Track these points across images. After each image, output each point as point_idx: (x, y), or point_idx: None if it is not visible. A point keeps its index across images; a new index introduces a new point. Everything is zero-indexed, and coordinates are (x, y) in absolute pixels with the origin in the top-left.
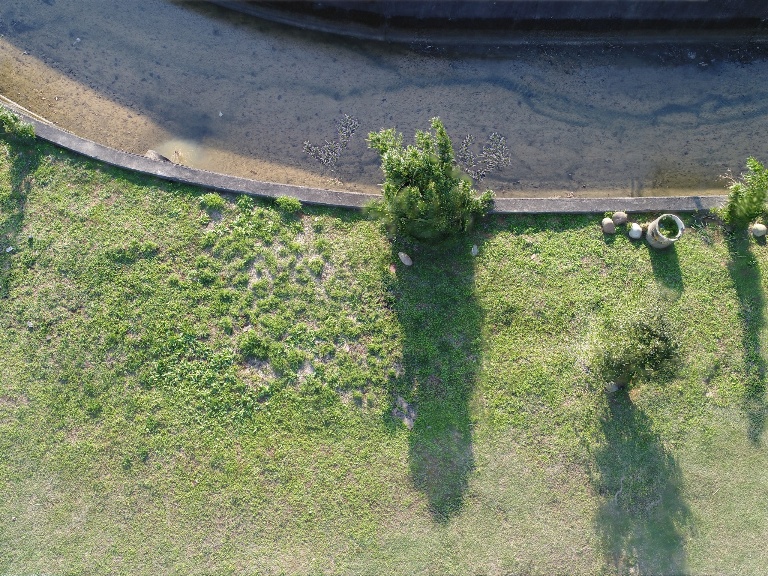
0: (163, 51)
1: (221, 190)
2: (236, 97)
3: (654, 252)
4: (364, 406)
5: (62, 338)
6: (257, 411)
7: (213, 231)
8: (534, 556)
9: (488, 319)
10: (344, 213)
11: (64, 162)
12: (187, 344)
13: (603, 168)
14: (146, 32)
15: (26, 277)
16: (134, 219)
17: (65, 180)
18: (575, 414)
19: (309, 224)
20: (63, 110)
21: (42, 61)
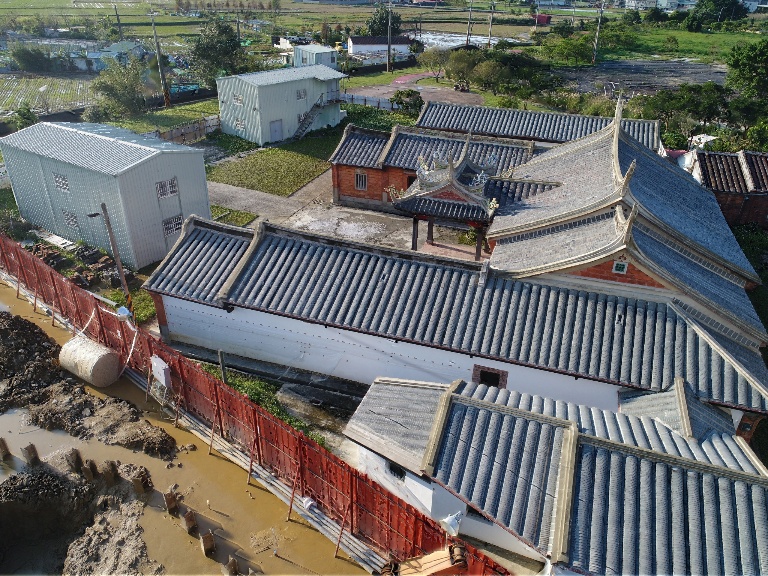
0: None
1: None
2: None
3: None
4: None
5: None
6: None
7: None
8: None
9: None
10: None
11: None
12: None
13: None
14: None
15: None
16: None
17: None
18: None
19: None
20: None
21: None
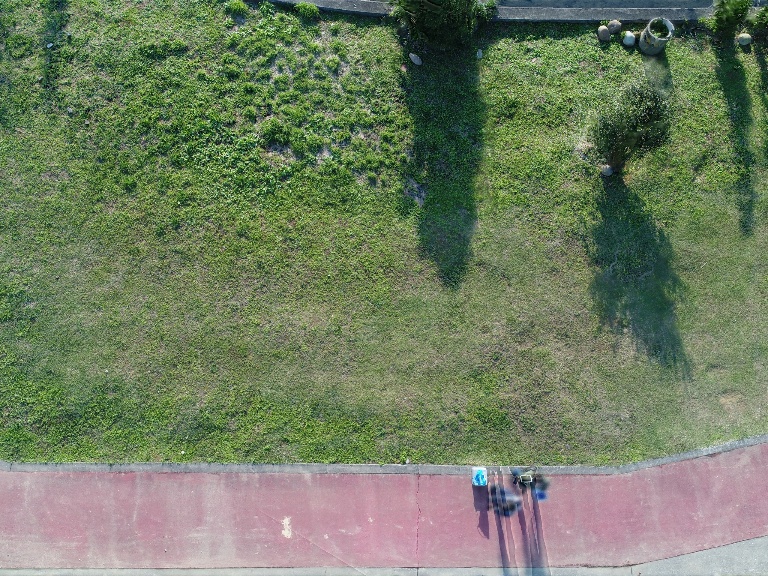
0: None
1: None
2: None
3: (646, 58)
4: (378, 186)
5: (99, 123)
6: (279, 189)
7: (237, 32)
8: (535, 317)
9: (492, 113)
10: (358, 20)
11: None
12: (214, 129)
13: (599, 2)
14: None
15: (65, 70)
16: (164, 21)
17: None
18: (573, 195)
19: (326, 29)
20: None
21: None
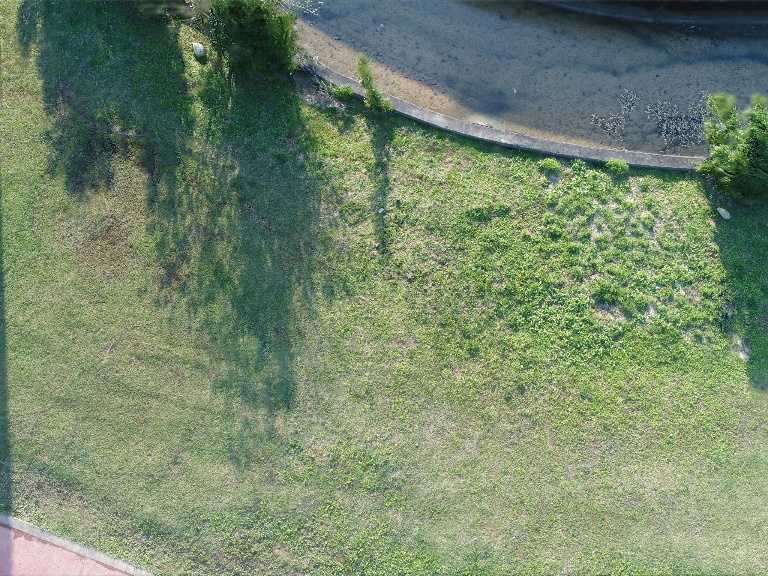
0: (457, 35)
1: (556, 155)
2: (527, 75)
3: None
4: (704, 343)
5: (436, 288)
6: (613, 349)
7: (555, 192)
8: None
9: None
10: (664, 174)
11: (417, 133)
12: (546, 291)
13: None
14: (440, 18)
15: (398, 235)
16: (485, 182)
17: (419, 149)
18: None
19: (635, 184)
20: (376, 89)
21: (352, 45)
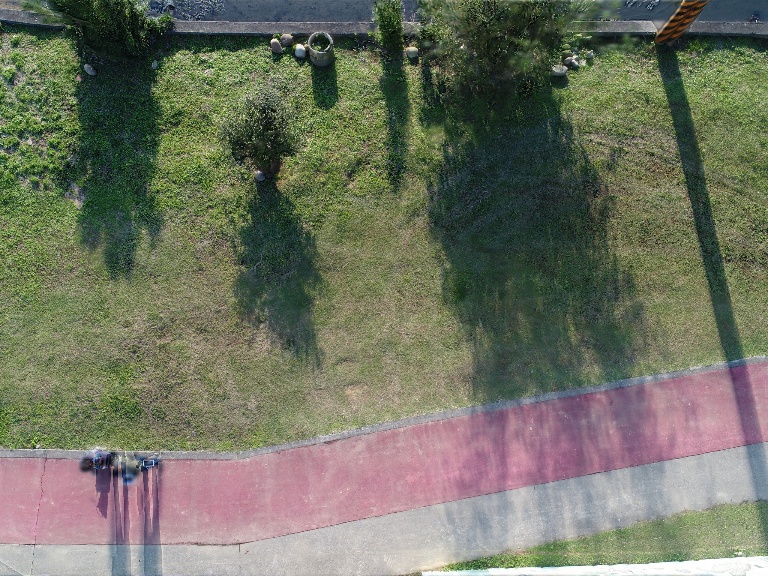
0: None
1: None
2: None
3: (316, 69)
4: (40, 189)
5: None
6: None
7: None
8: (177, 313)
9: (159, 121)
10: (41, 32)
11: None
12: None
13: (308, 14)
14: None
15: None
16: None
17: None
18: (226, 199)
19: (8, 40)
20: None
21: None
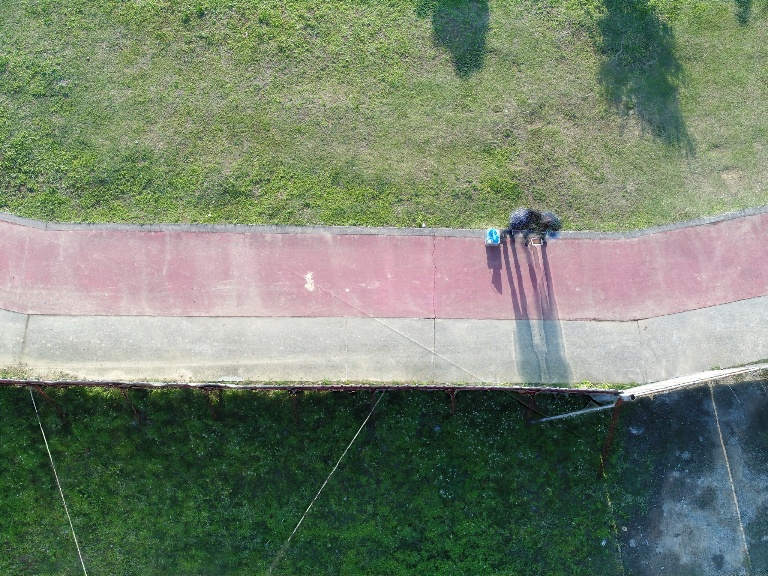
0: None
1: None
2: None
3: None
4: None
5: None
6: None
7: None
8: (544, 99)
9: None
10: None
11: None
12: None
13: None
14: None
15: None
16: None
17: None
18: None
19: None
20: None
21: None
